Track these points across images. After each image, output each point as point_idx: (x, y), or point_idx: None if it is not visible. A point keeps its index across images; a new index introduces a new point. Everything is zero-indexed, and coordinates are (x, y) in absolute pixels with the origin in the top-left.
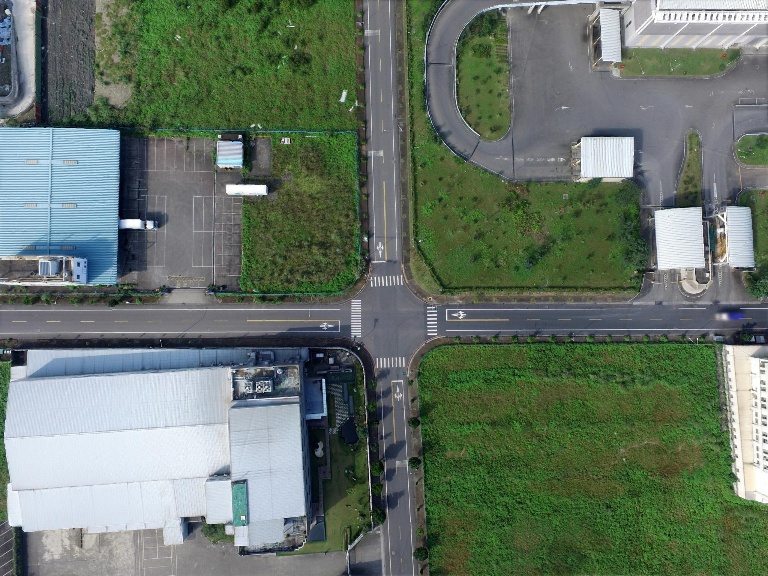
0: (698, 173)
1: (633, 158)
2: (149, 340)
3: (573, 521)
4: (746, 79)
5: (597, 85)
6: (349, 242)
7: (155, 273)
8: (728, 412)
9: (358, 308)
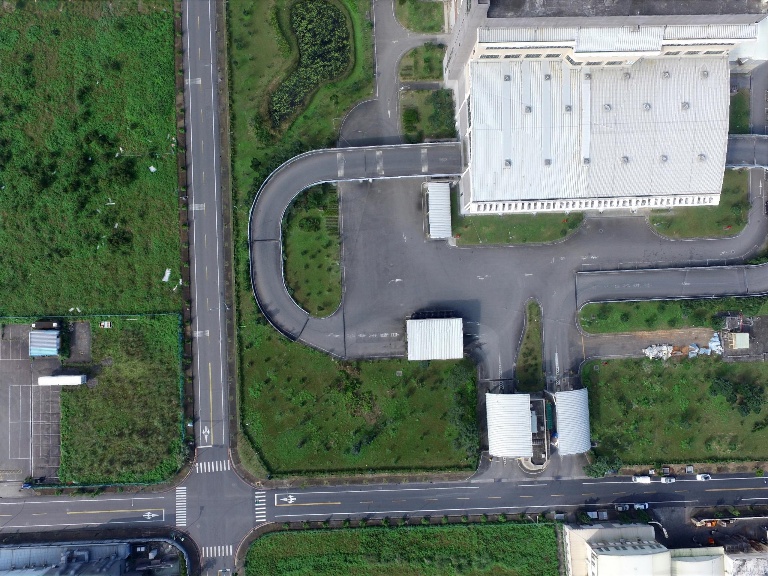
0: (538, 344)
1: (462, 339)
2: None
3: None
4: (589, 244)
5: (432, 255)
6: (173, 428)
7: None
8: None
9: (183, 496)
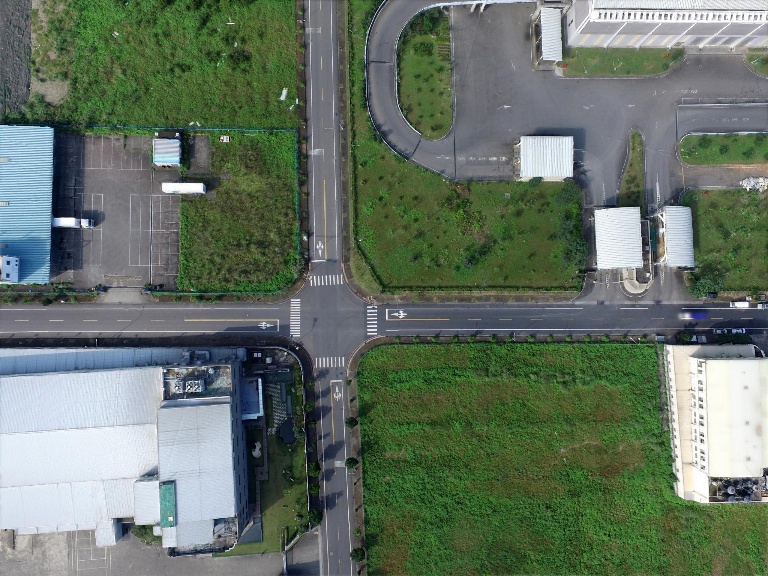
0: (641, 173)
1: None
2: (84, 339)
3: (513, 521)
4: (689, 79)
5: (540, 84)
6: (288, 241)
7: (91, 272)
8: (669, 412)
9: (297, 307)
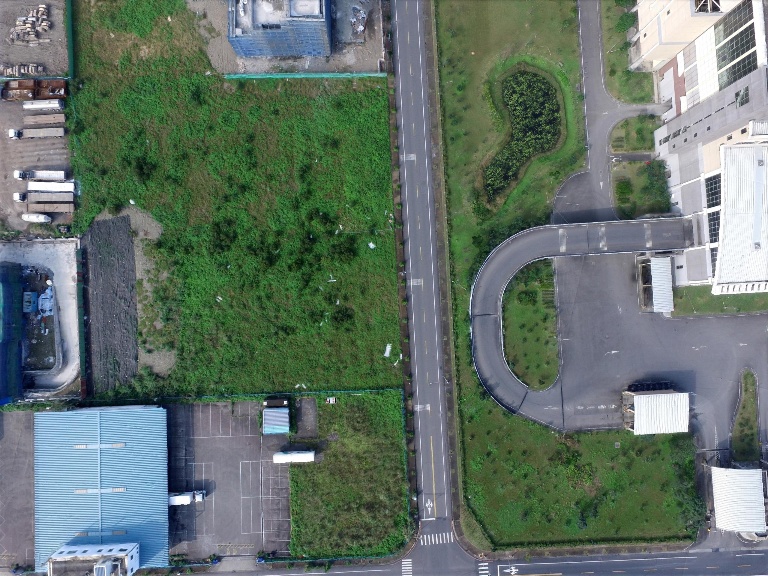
0: (754, 414)
1: (688, 414)
2: None
3: None
4: None
5: (647, 327)
6: (398, 501)
7: (205, 542)
8: None
9: (409, 568)
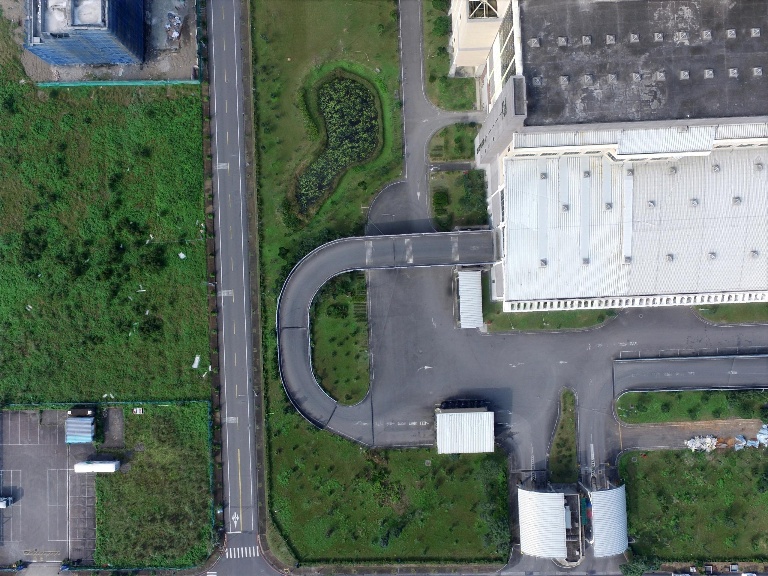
0: (573, 435)
1: (493, 433)
2: None
3: None
4: (628, 330)
5: (462, 342)
6: (203, 513)
7: (12, 548)
8: None
9: None
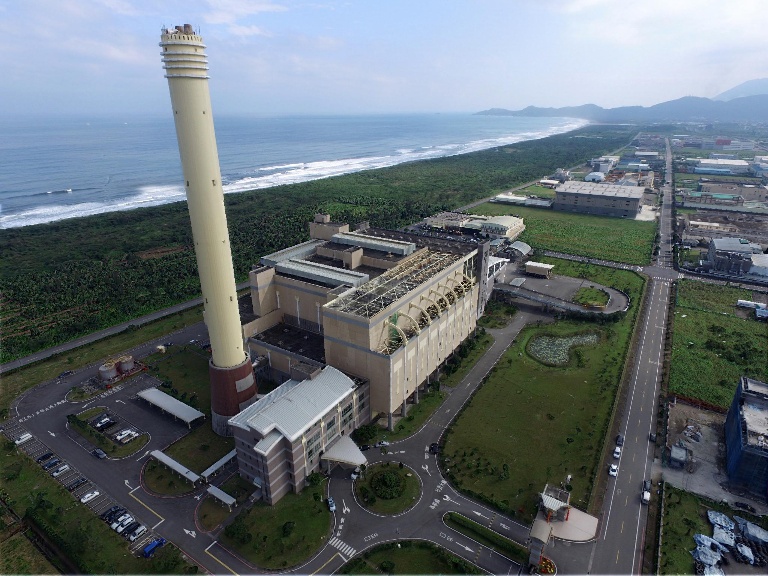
0: None
1: None
2: None
3: None
4: None
5: (525, 285)
6: None
7: None
8: None
9: None
